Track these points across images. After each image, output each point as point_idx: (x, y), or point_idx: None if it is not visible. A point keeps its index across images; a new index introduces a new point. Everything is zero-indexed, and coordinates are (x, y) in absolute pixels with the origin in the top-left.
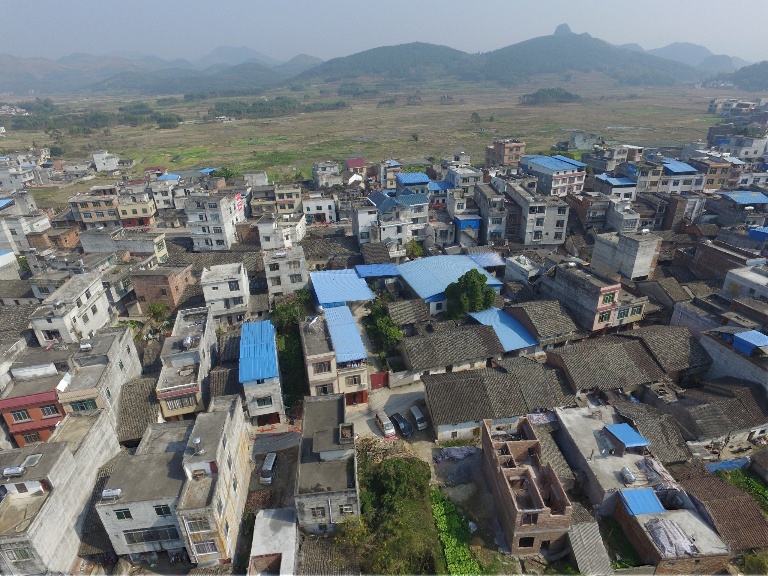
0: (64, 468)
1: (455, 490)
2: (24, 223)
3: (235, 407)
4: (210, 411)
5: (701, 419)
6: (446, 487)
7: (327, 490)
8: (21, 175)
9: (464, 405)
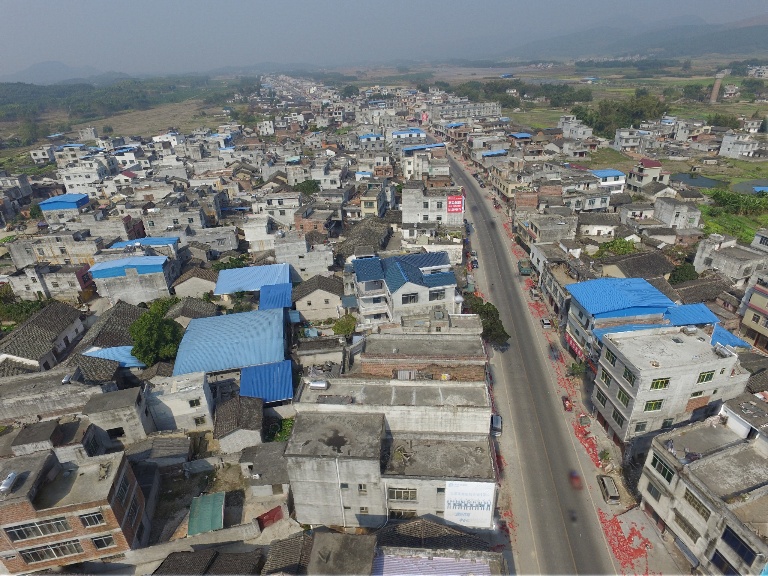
0: (89, 220)
1: None
2: (426, 165)
3: (85, 241)
4: (93, 238)
5: None
6: None
7: (22, 274)
8: (624, 139)
9: None
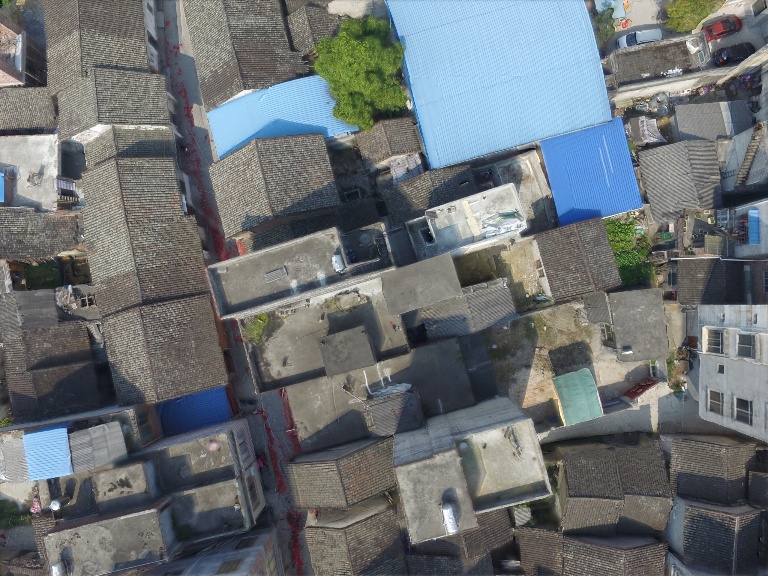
0: None
1: (1, 8)
2: None
3: None
4: None
5: (7, 303)
6: (13, 3)
7: None
8: None
9: (56, 6)
